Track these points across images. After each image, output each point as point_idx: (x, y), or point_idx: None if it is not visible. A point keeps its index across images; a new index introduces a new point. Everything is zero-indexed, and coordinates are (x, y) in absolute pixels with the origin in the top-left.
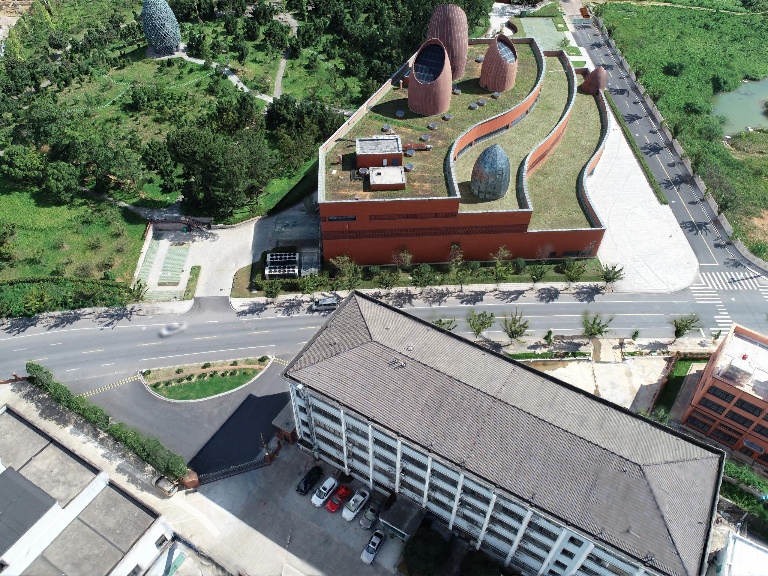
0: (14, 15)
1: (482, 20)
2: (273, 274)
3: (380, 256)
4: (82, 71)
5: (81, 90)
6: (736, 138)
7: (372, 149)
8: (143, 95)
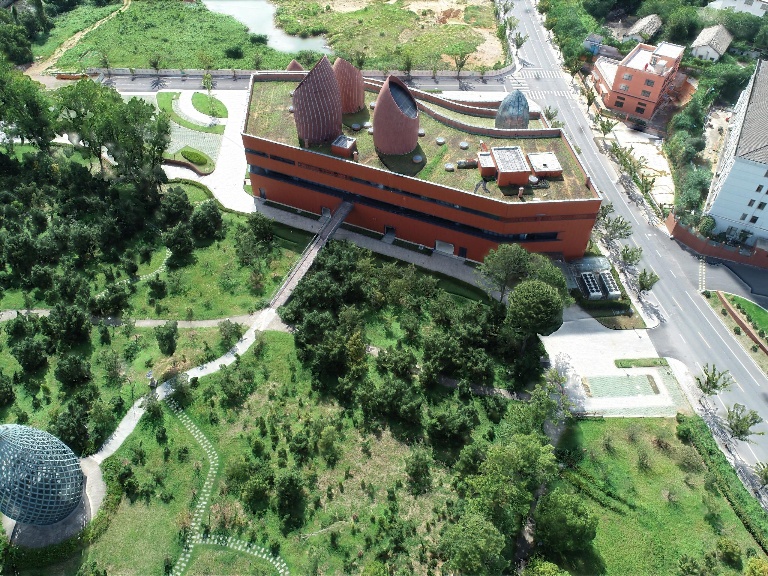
0: None
1: None
2: None
3: None
4: None
5: None
6: None
7: (515, 164)
8: None
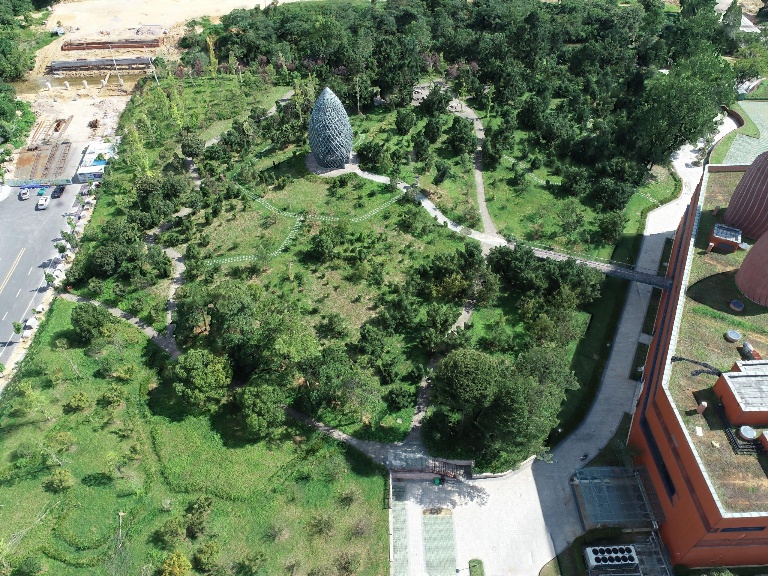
0: (117, 94)
1: None
2: None
3: (763, 558)
4: (232, 194)
5: (235, 223)
6: None
7: (758, 397)
8: (329, 242)
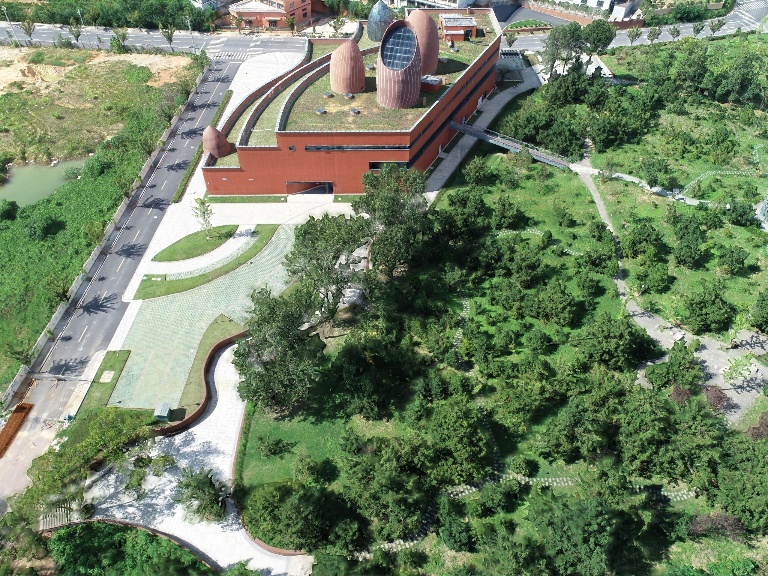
0: None
1: (259, 419)
2: (514, 50)
3: None
4: None
5: None
6: (90, 148)
7: (464, 21)
8: None
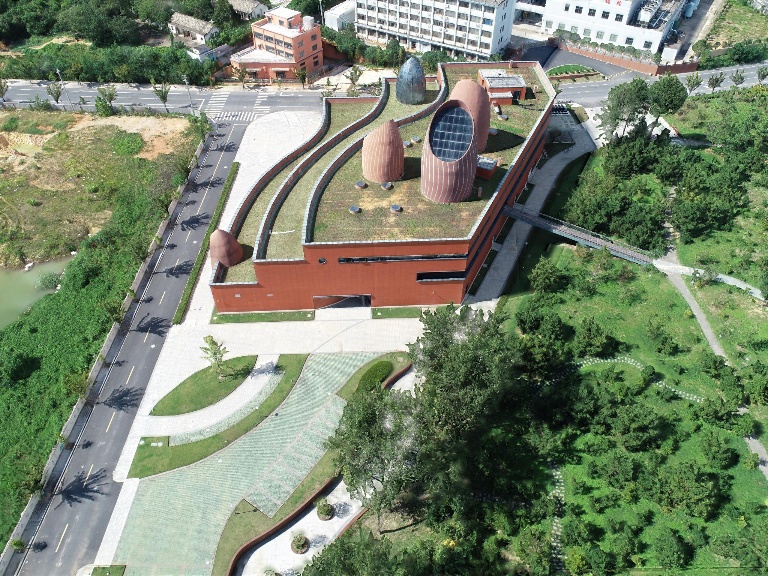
0: None
1: None
2: None
3: None
4: None
5: None
6: (71, 244)
7: (510, 81)
8: None
